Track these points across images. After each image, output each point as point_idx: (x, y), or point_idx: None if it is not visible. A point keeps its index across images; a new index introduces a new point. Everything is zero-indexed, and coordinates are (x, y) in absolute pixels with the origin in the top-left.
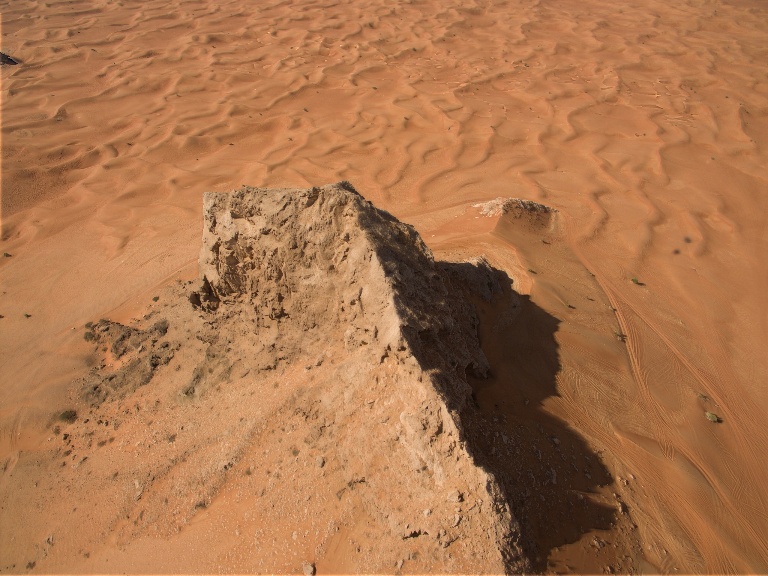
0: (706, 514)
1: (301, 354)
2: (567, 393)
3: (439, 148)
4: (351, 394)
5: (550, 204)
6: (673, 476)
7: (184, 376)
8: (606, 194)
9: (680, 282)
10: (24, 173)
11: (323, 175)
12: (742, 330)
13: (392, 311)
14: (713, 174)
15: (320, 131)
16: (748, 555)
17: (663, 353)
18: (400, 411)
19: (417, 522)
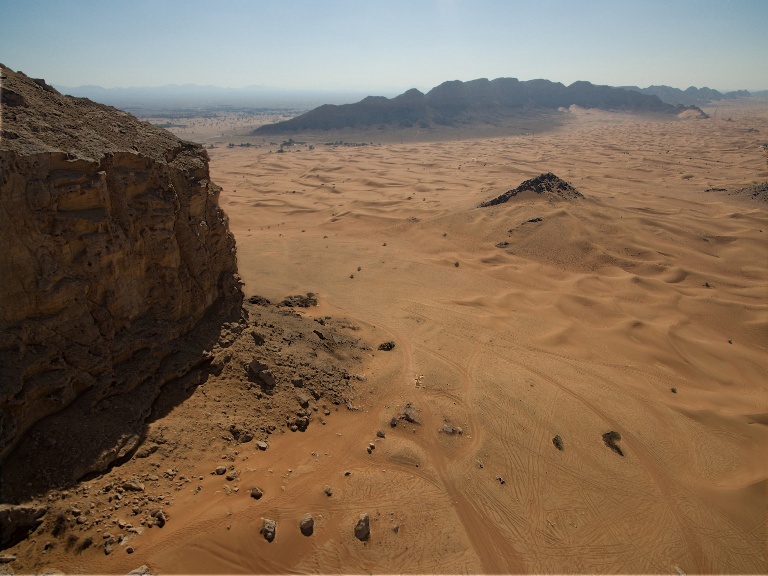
0: None
1: None
2: None
3: None
4: None
5: None
6: None
7: None
8: None
9: None
10: (585, 245)
11: None
12: None
13: None
14: None
15: None
16: None
17: None
18: None
19: None
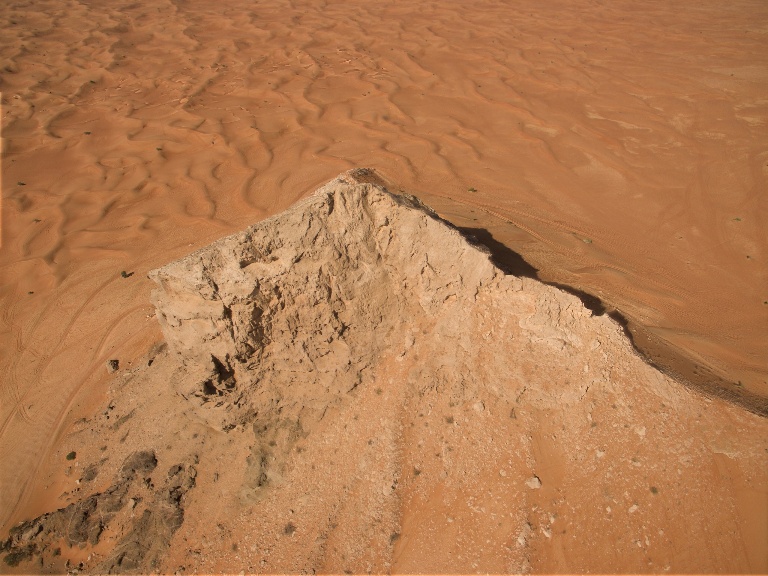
0: (639, 288)
1: (381, 352)
2: (538, 267)
3: (220, 163)
4: (468, 340)
5: (364, 167)
6: (613, 279)
7: (232, 478)
8: (388, 145)
9: (490, 179)
10: None
11: (124, 237)
12: (543, 190)
13: (473, 252)
14: (433, 105)
15: (70, 197)
16: (667, 294)
17: (534, 222)
18: (517, 322)
19: (585, 380)
